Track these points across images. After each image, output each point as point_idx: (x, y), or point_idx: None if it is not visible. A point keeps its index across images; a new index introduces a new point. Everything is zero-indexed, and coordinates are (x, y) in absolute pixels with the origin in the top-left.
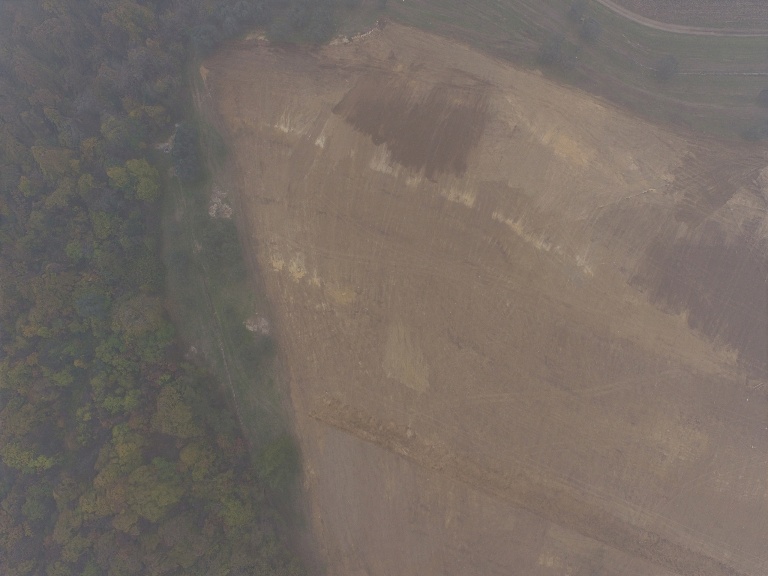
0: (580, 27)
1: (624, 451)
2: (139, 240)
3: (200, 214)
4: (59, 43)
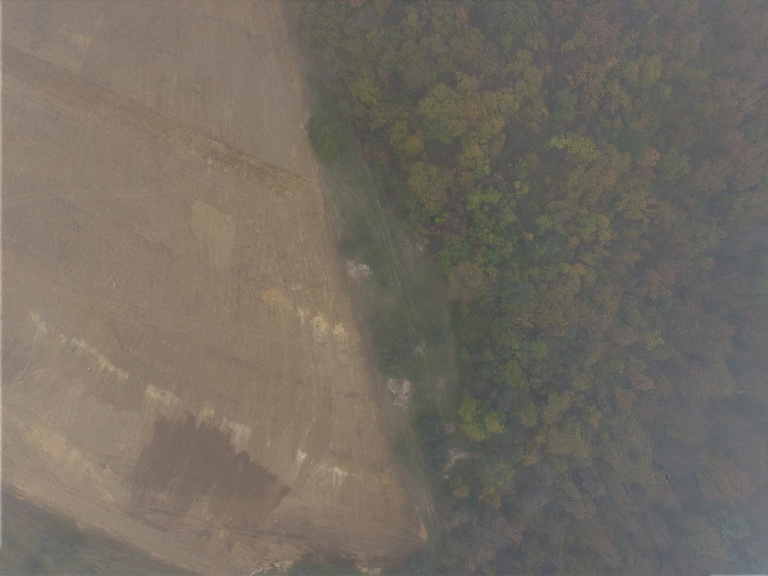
0: (43, 575)
1: (6, 139)
2: (476, 358)
3: (416, 383)
4: (570, 568)
